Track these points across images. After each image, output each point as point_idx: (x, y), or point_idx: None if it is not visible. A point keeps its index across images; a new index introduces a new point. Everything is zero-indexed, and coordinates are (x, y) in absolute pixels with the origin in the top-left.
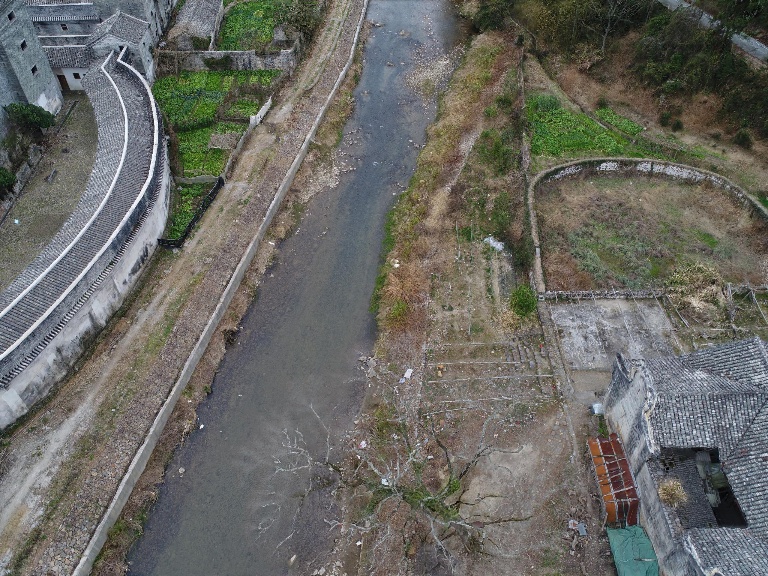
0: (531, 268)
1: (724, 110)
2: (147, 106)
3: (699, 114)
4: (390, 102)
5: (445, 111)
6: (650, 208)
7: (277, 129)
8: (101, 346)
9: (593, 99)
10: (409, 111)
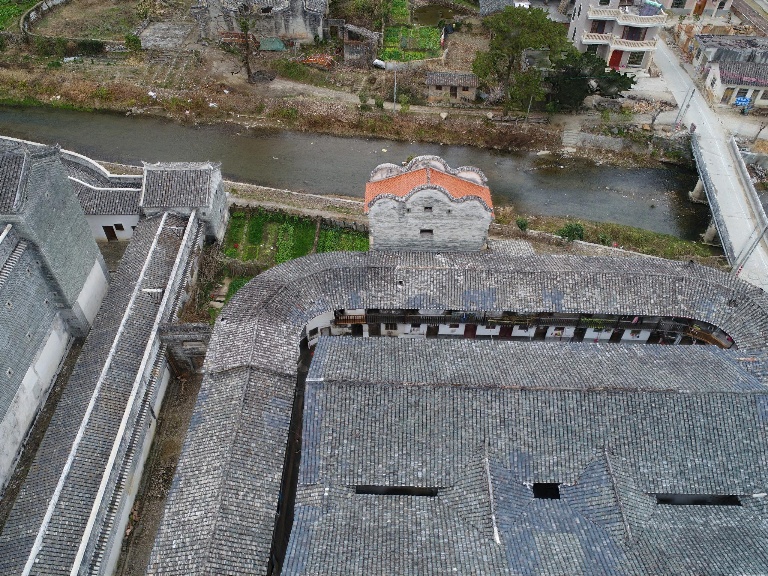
0: (105, 45)
1: None
2: None
3: None
4: None
5: None
6: (77, 18)
7: None
8: None
9: None
10: None
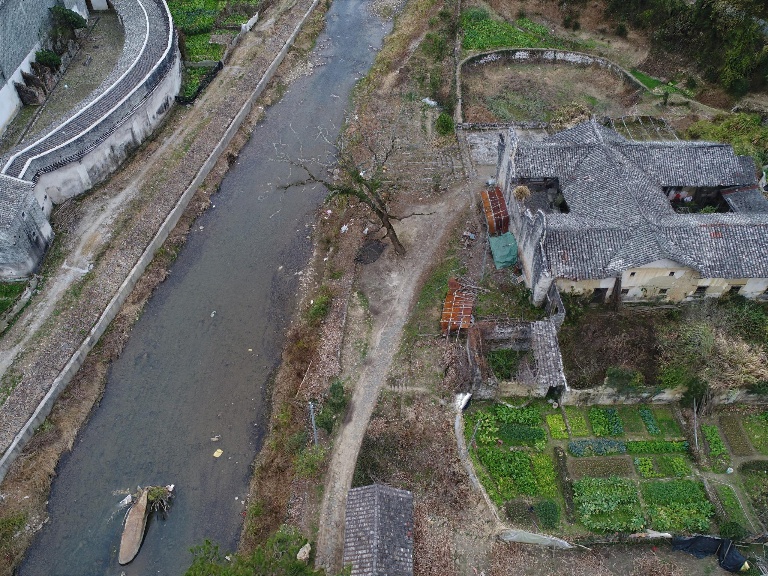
0: (454, 112)
1: (608, 10)
2: (161, 9)
3: (592, 16)
4: (355, 21)
5: (399, 26)
6: (551, 83)
7: (263, 34)
8: (139, 156)
9: (515, 12)
10: (370, 27)
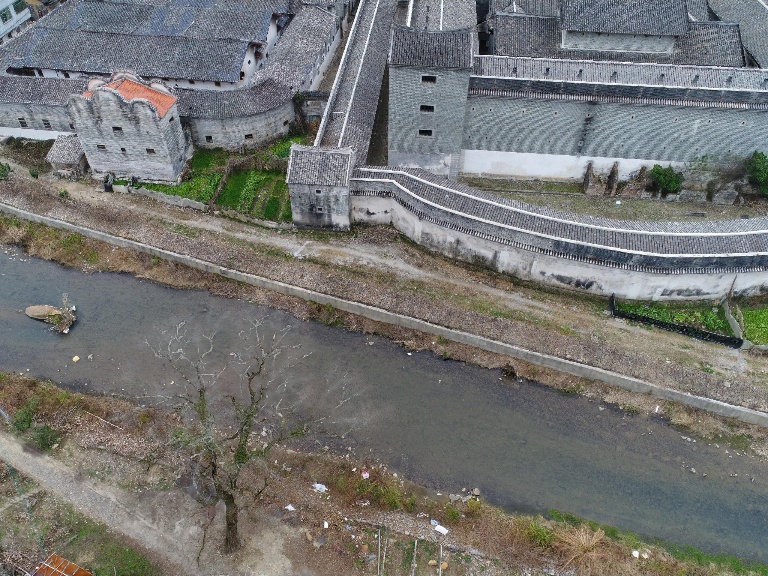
0: None
1: None
2: None
3: None
4: None
5: None
6: None
7: None
8: (481, 274)
9: None
10: None
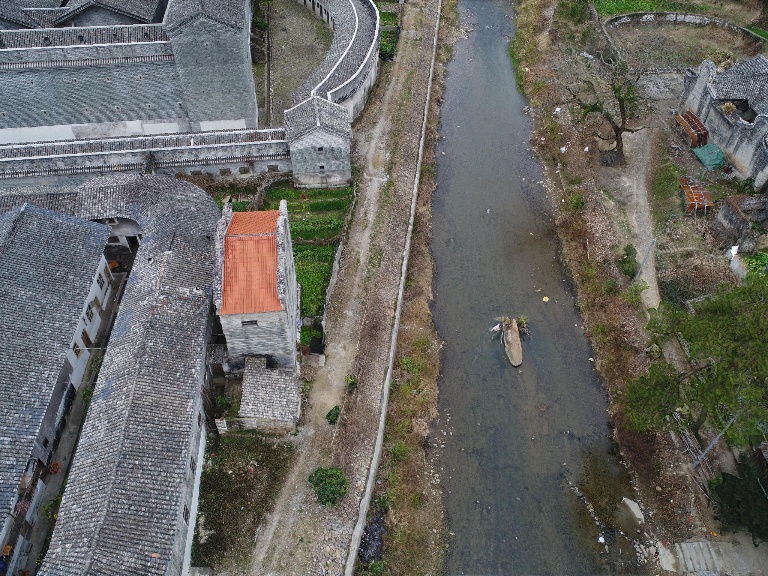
0: None
1: None
2: None
3: None
4: None
5: None
6: (678, 40)
7: (418, 5)
8: (374, 99)
9: None
10: (498, 0)
